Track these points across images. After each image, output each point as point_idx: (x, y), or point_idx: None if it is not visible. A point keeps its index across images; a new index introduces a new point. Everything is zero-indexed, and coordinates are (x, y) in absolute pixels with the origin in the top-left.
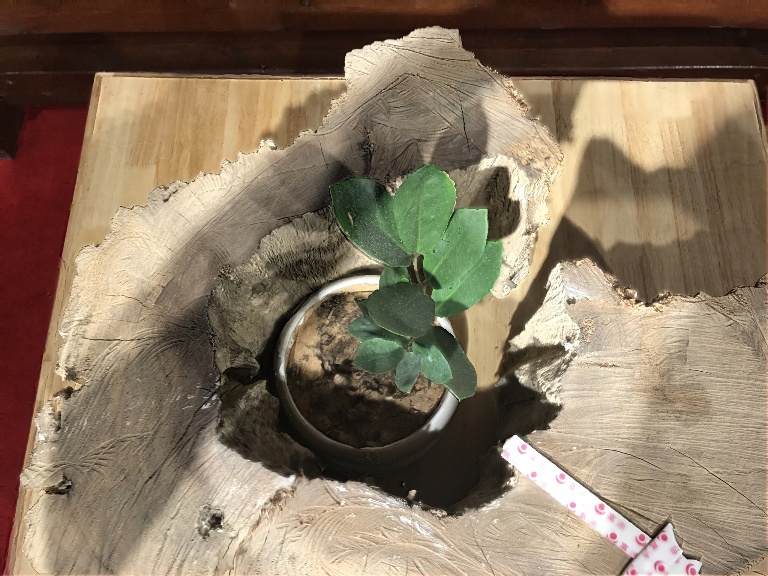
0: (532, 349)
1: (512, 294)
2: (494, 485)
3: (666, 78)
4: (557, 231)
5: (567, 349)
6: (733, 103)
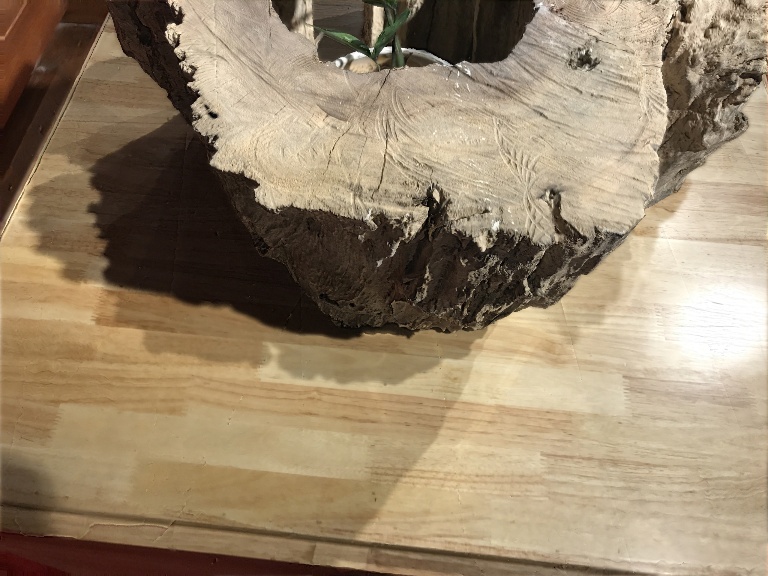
0: None
1: None
2: (510, 18)
3: None
4: None
5: None
6: None
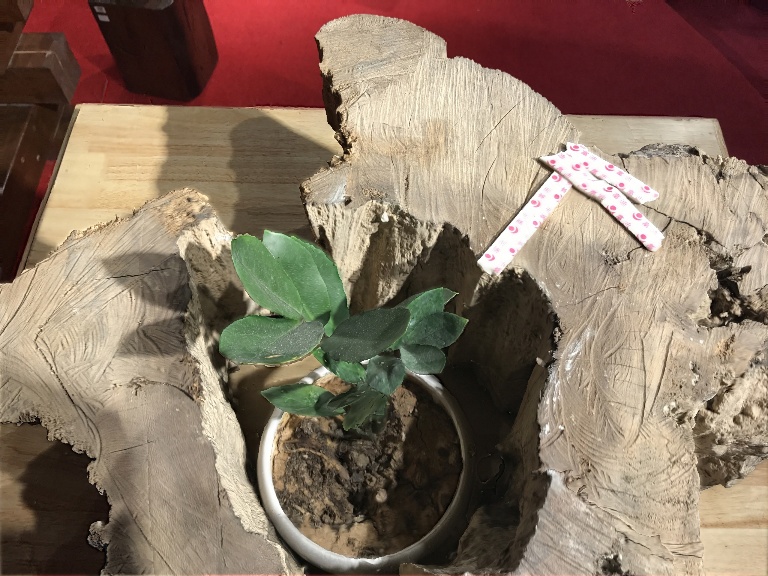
0: (357, 288)
1: None
2: (497, 322)
3: (53, 171)
4: None
5: (387, 219)
6: (100, 120)
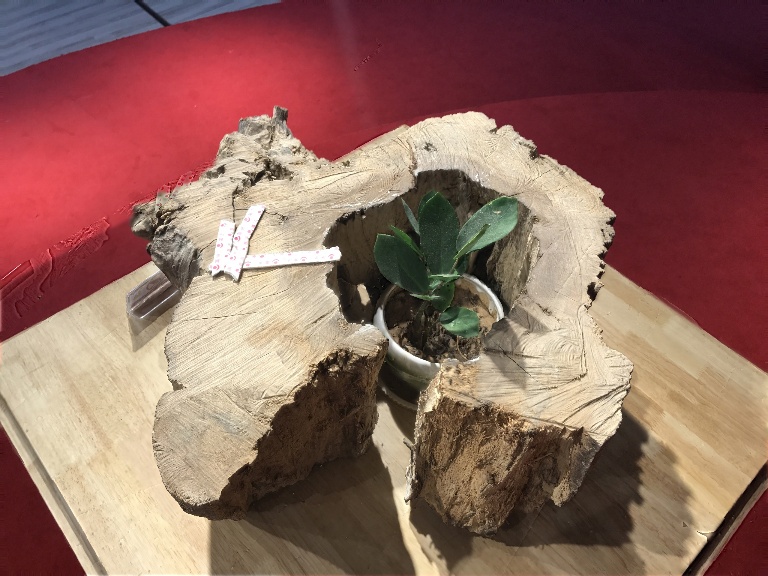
0: None
1: (403, 490)
2: None
3: None
4: (414, 572)
5: None
6: None
